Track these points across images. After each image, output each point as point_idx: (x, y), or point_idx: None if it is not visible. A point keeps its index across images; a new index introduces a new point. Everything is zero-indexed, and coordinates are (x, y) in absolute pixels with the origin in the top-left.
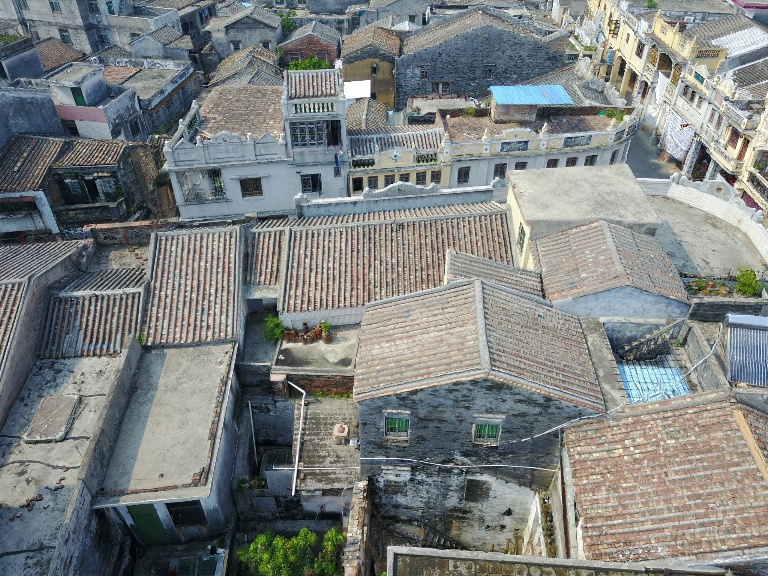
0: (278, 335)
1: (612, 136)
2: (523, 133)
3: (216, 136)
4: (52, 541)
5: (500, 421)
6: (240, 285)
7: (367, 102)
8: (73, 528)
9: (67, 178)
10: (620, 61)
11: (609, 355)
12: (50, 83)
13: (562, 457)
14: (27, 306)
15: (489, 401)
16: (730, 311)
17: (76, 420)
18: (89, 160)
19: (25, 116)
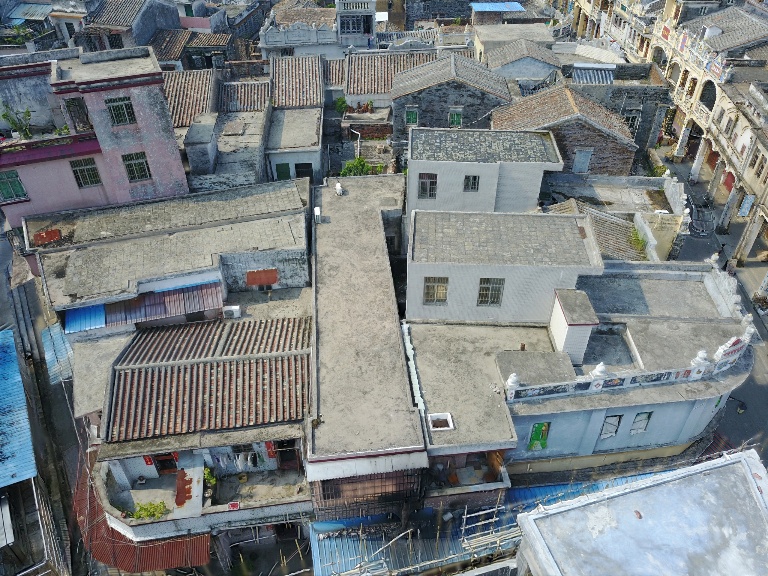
0: (344, 109)
1: (551, 33)
2: None
3: (293, 24)
4: (250, 159)
5: (461, 110)
6: (323, 81)
7: (386, 23)
8: (261, 151)
9: (194, 55)
10: (578, 10)
11: (518, 89)
12: (172, 1)
13: (491, 124)
14: (213, 82)
15: (456, 96)
16: None
17: (246, 130)
18: (209, 43)
19: (164, 17)
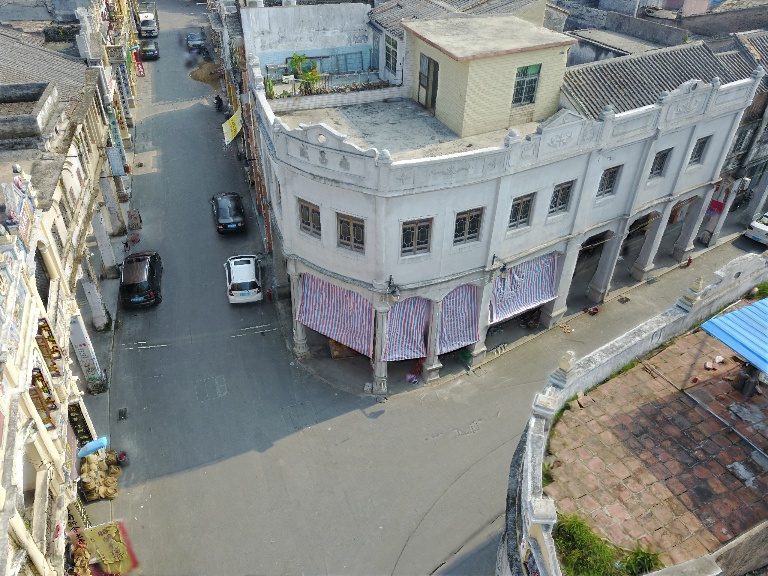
0: None
1: None
2: None
3: None
4: None
5: None
6: None
7: None
8: None
9: None
10: None
11: None
12: None
13: None
14: (750, 12)
15: None
16: None
17: None
18: None
19: None
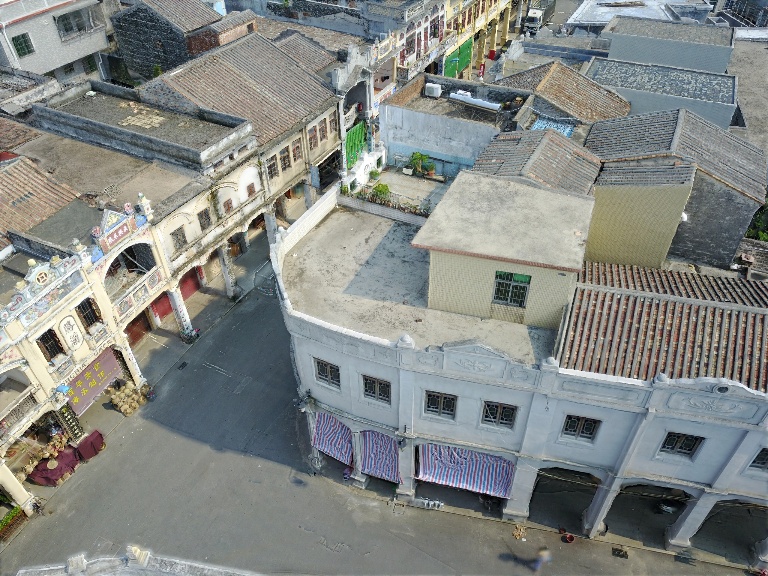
0: None
1: None
2: None
3: None
4: None
5: None
6: None
7: None
8: None
9: None
10: None
11: None
12: None
13: None
14: None
15: None
16: None
17: None
18: None
19: None
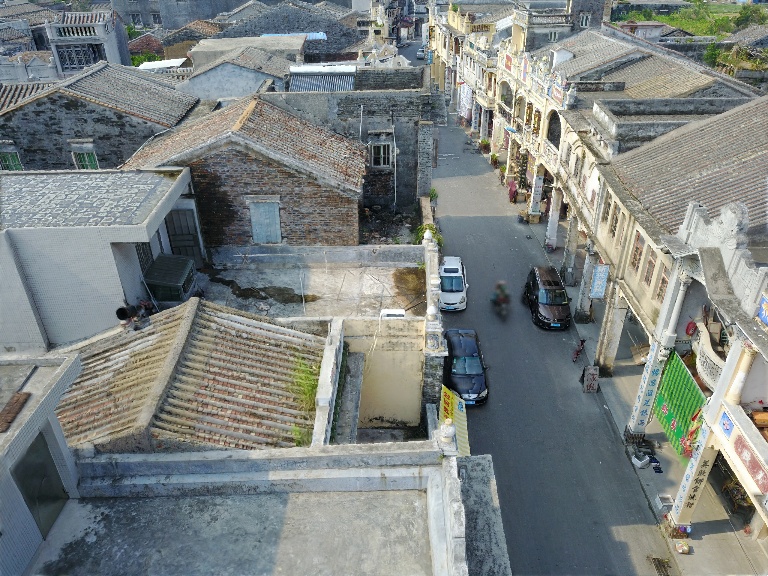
0: None
1: None
2: None
3: None
4: None
5: (92, 146)
6: None
7: None
8: None
9: None
10: None
11: (207, 112)
12: None
13: None
14: None
15: (74, 123)
16: None
17: None
18: None
19: None
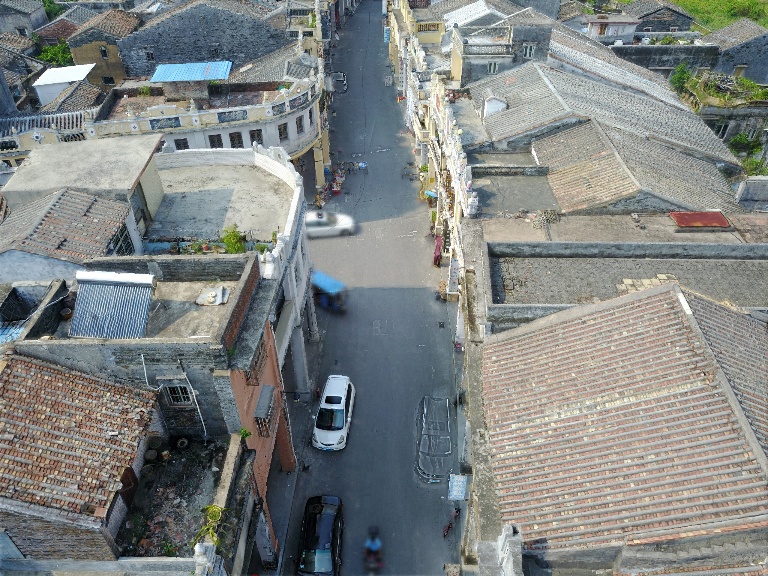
0: None
1: (269, 110)
2: (169, 110)
3: None
4: None
5: None
6: None
7: (76, 85)
8: None
9: None
10: None
11: None
12: None
13: None
14: None
15: None
16: (121, 269)
17: None
18: None
19: None
